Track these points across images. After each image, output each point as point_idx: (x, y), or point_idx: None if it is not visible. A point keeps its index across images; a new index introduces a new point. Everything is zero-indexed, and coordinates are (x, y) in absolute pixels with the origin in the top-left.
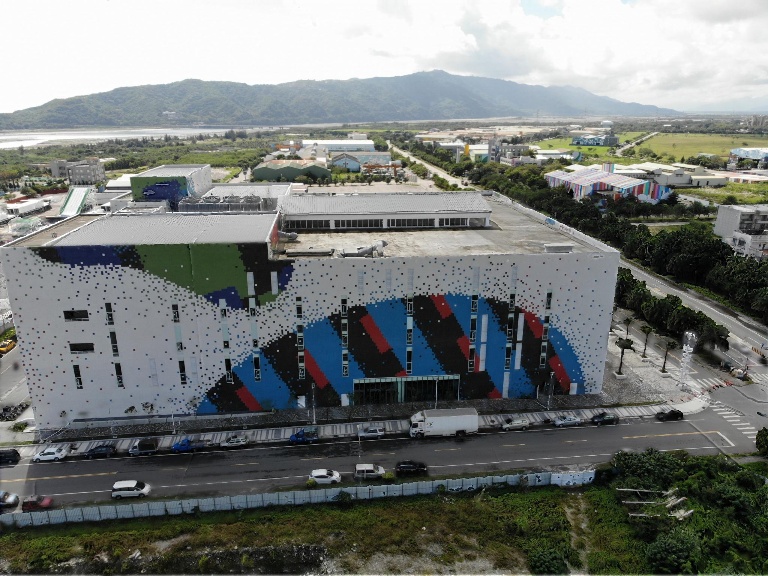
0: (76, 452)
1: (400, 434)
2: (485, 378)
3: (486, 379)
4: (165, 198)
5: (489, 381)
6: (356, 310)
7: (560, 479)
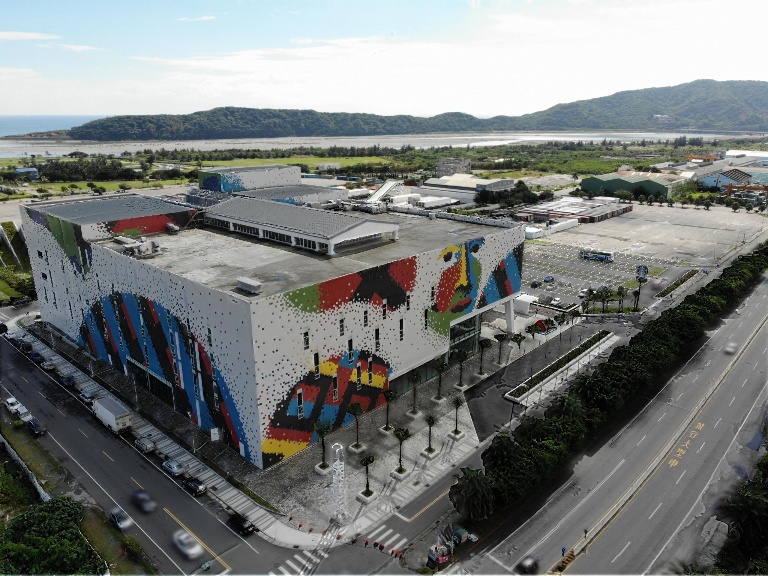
0: None
1: None
2: (186, 397)
3: (187, 398)
4: (212, 189)
5: (189, 402)
6: (118, 295)
7: None
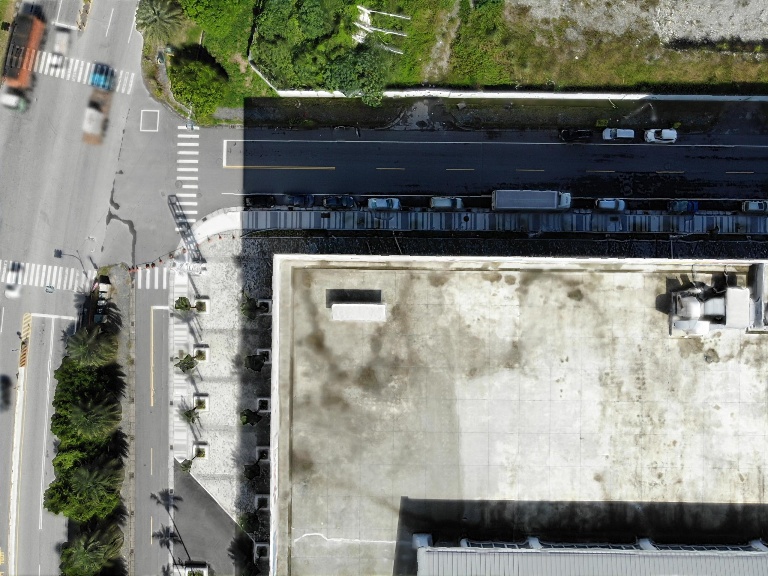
0: None
1: (577, 205)
2: None
3: None
4: None
5: None
6: None
7: (440, 94)
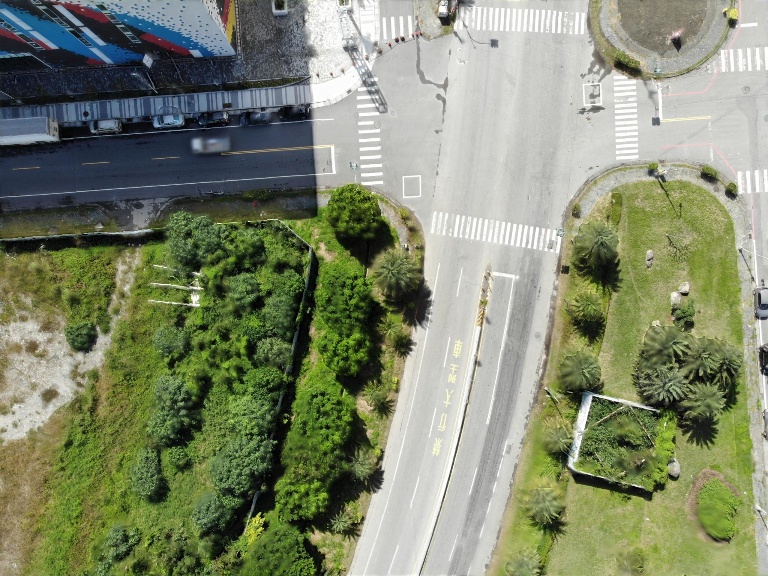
0: None
1: None
2: (67, 53)
3: (69, 53)
4: None
5: (75, 54)
6: None
7: (119, 233)
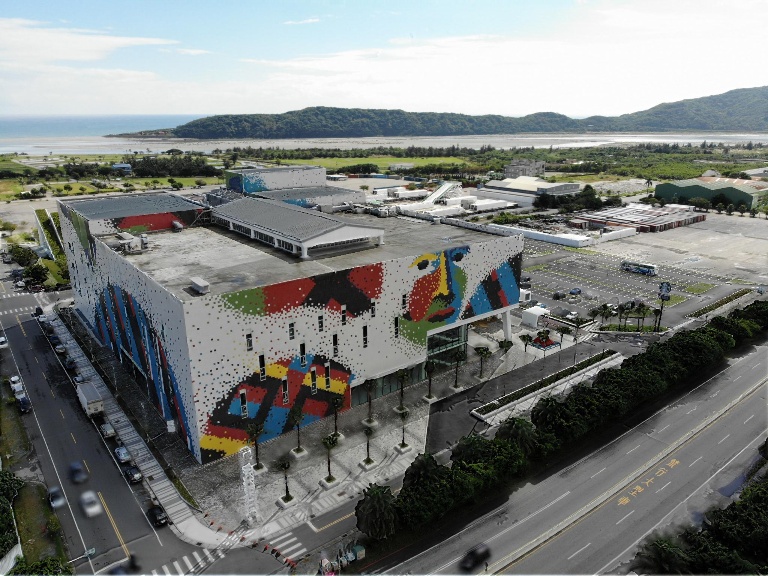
0: (50, 322)
1: None
2: None
3: None
4: None
5: None
6: None
7: None
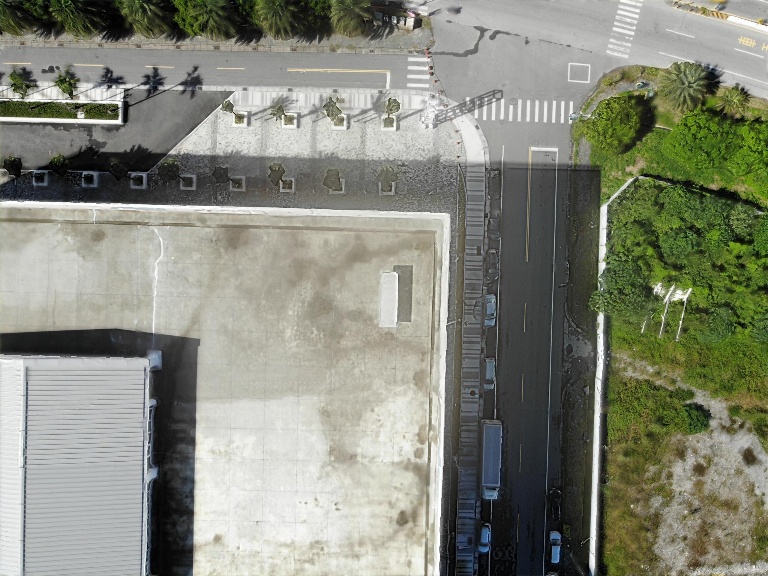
0: None
1: (485, 504)
2: None
3: None
4: None
5: None
6: None
7: None
